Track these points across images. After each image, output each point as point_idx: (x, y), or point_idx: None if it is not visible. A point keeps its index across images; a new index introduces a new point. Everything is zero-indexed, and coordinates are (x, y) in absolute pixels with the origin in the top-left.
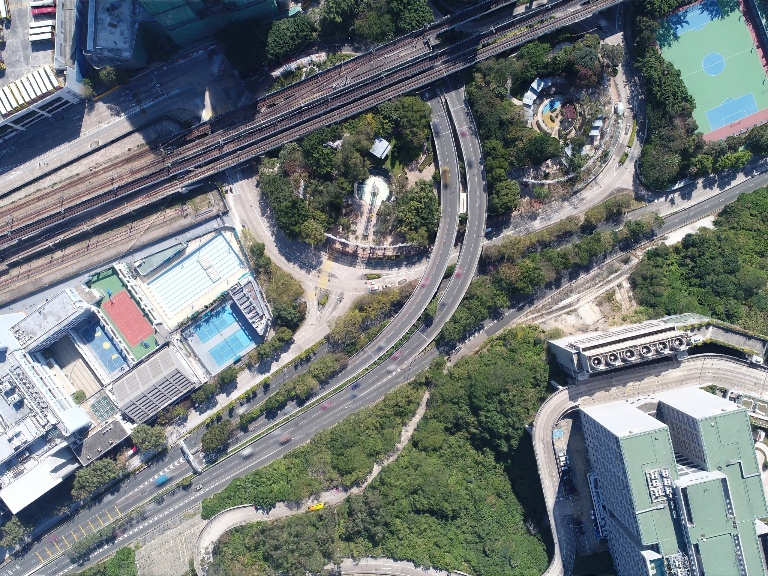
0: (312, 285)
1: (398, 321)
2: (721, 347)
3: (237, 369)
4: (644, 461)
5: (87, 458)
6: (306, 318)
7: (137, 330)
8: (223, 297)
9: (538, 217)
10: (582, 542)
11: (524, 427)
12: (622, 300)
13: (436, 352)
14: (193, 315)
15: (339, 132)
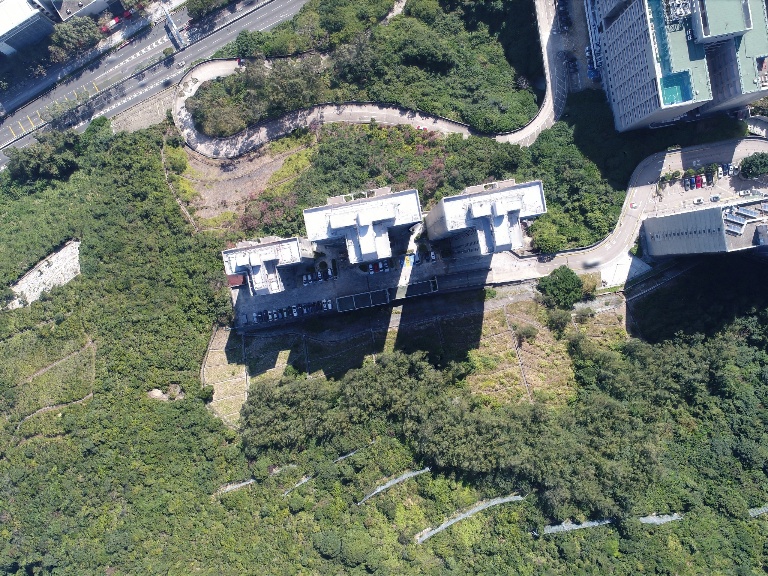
0: None
1: None
2: None
3: None
4: None
5: (67, 11)
6: None
7: None
8: None
9: None
10: (575, 81)
11: None
12: None
13: None
14: None
15: None
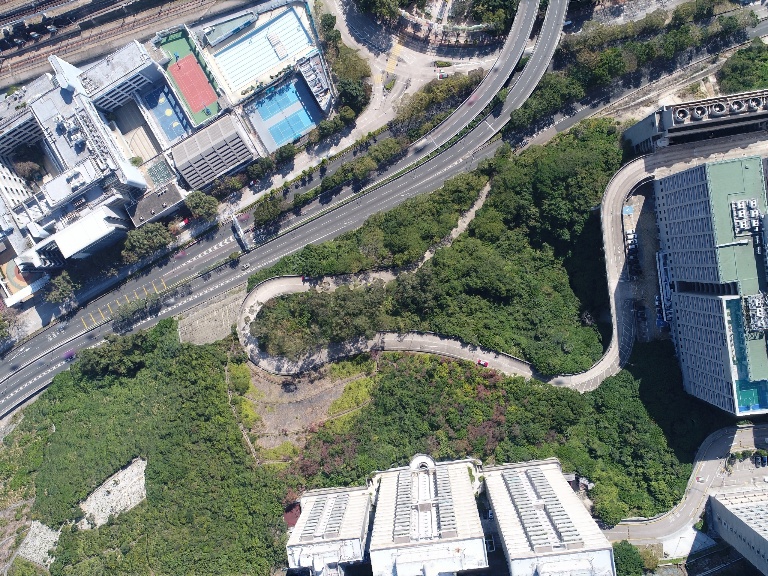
0: (379, 69)
1: (465, 109)
2: None
3: (295, 149)
4: (731, 191)
5: (140, 219)
6: (370, 103)
7: (200, 96)
8: (289, 71)
9: (622, 13)
10: (643, 329)
11: (591, 210)
12: (707, 92)
13: (501, 144)
14: (257, 86)
15: None
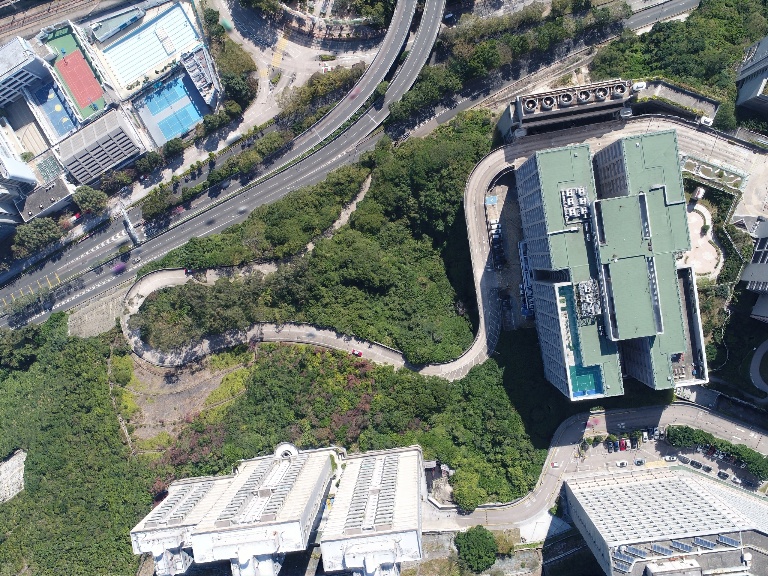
0: (265, 63)
1: (348, 102)
2: None
3: (184, 144)
4: (561, 179)
5: (29, 214)
6: (257, 97)
7: (88, 92)
8: (175, 66)
9: (502, 6)
10: (508, 318)
11: (461, 200)
12: (578, 83)
13: None
14: (143, 81)
15: None
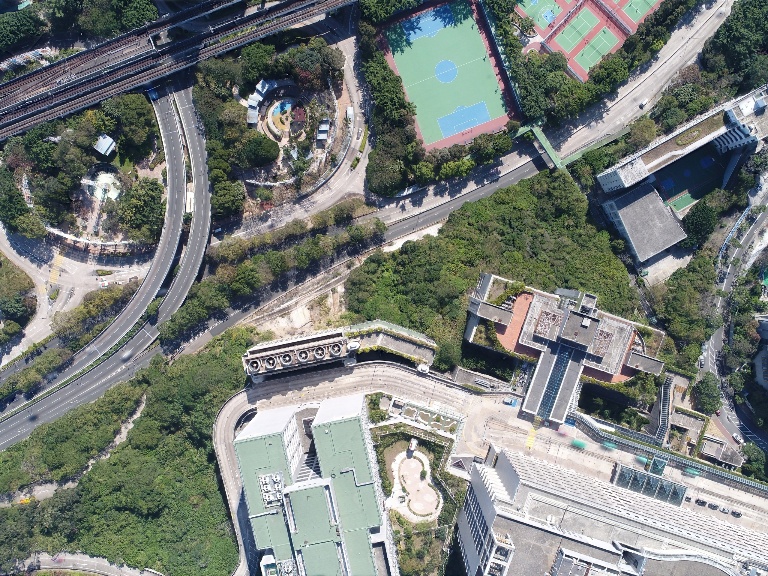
0: (43, 279)
1: (123, 318)
2: None
3: None
4: (258, 466)
5: None
6: (37, 312)
7: None
8: None
9: (269, 219)
10: None
11: None
12: (332, 305)
13: (160, 350)
14: None
15: (61, 127)
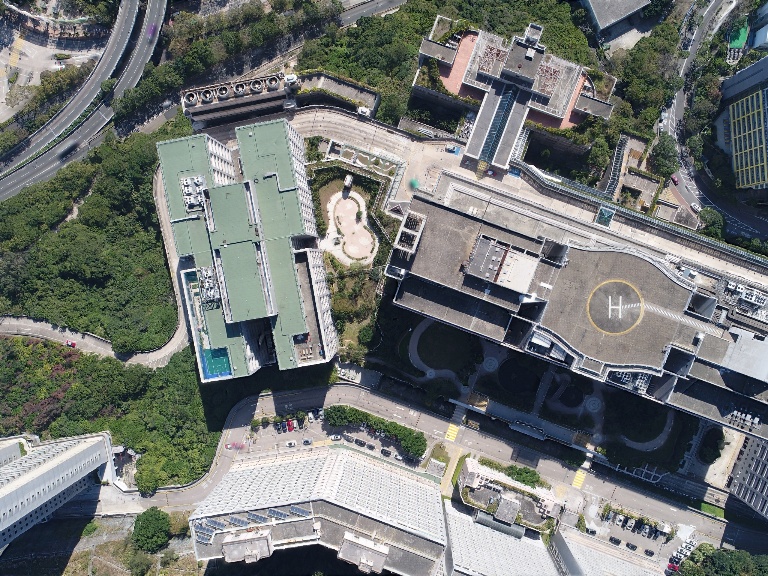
0: (3, 62)
1: (79, 99)
2: (348, 109)
3: None
4: (180, 169)
5: None
6: None
7: None
8: None
9: (228, 3)
10: None
11: None
12: None
13: (115, 133)
14: None
15: None
